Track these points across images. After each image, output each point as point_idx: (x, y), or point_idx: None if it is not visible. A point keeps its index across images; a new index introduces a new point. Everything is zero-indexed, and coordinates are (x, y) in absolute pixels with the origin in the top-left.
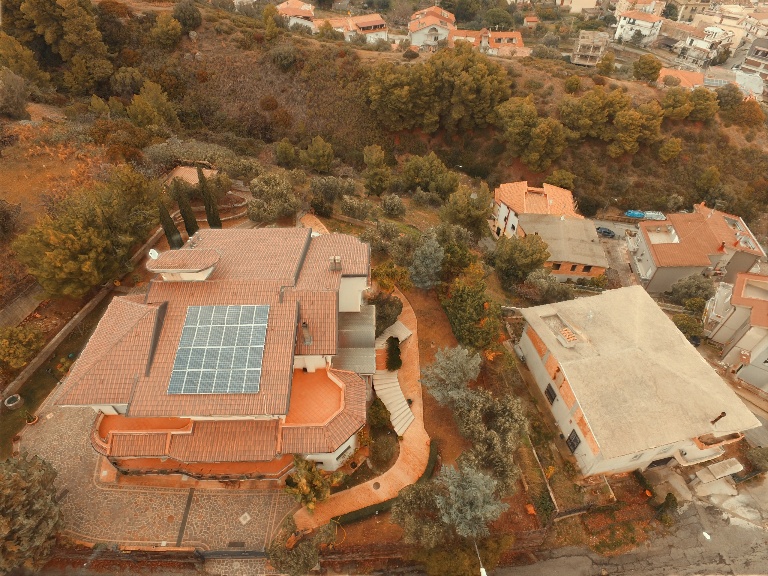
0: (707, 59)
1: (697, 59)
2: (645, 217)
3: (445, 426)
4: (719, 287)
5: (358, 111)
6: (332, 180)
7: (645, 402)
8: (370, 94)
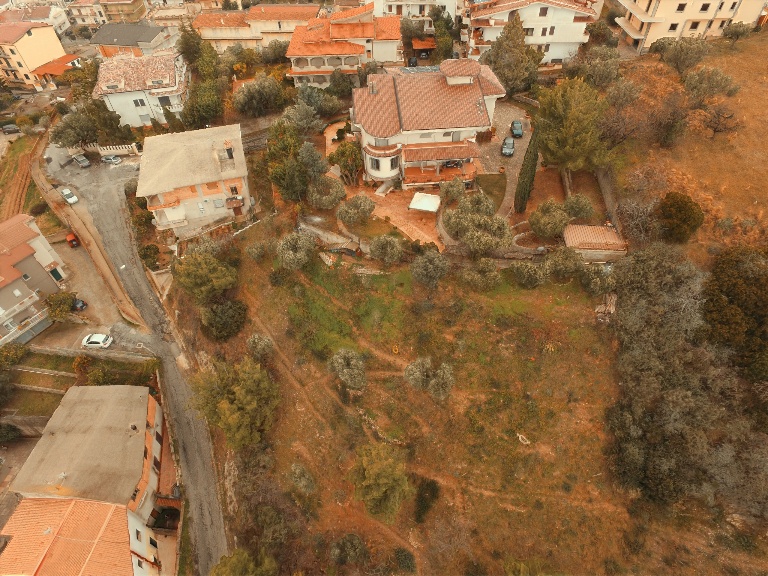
0: None
1: None
2: None
3: (315, 139)
4: None
5: None
6: (420, 261)
7: (202, 134)
8: None
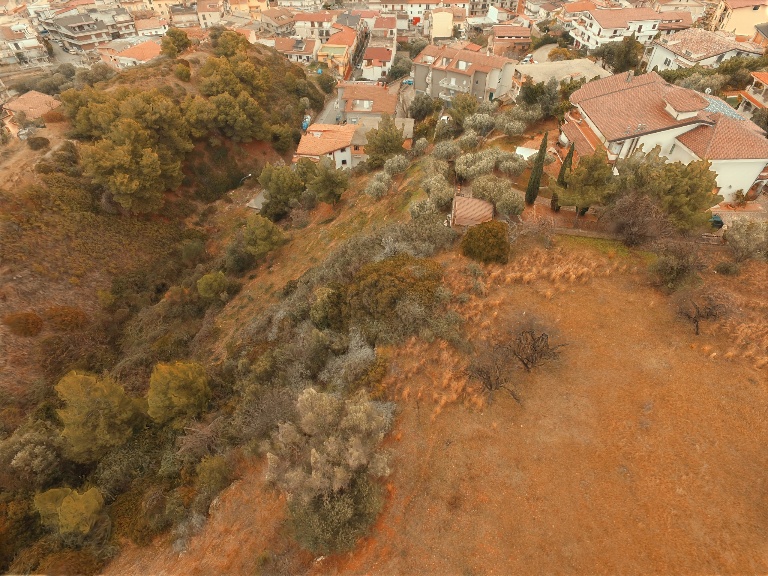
0: (47, 53)
1: (41, 57)
2: (308, 123)
3: None
4: (444, 83)
5: (106, 229)
6: None
7: (597, 71)
8: (124, 188)
